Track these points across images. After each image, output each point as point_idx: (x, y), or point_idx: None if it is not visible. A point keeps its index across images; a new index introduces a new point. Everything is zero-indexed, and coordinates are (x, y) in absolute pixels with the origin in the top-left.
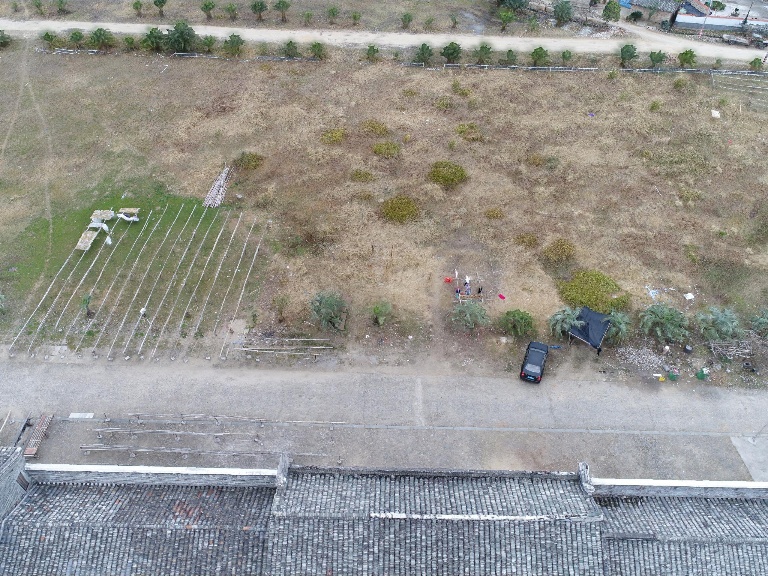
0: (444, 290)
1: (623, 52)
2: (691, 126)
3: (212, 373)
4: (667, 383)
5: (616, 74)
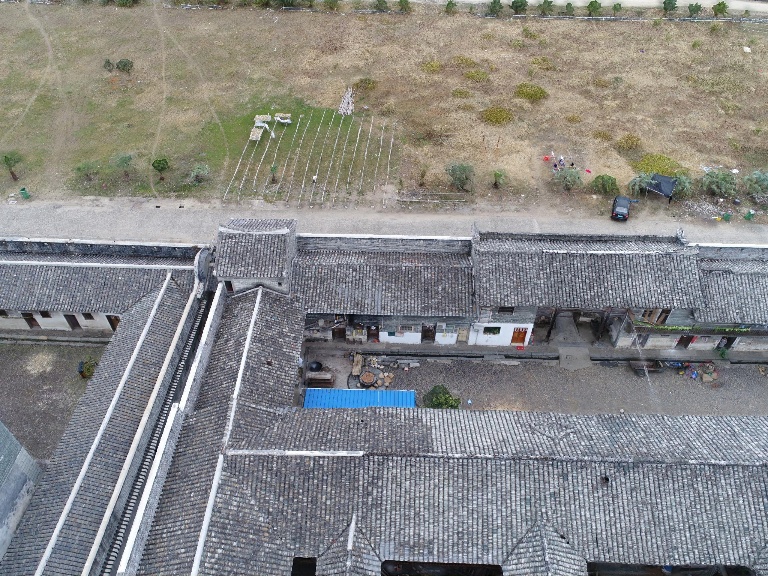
0: (543, 167)
1: (666, 4)
2: (727, 60)
3: (378, 216)
4: (723, 222)
5: (660, 21)
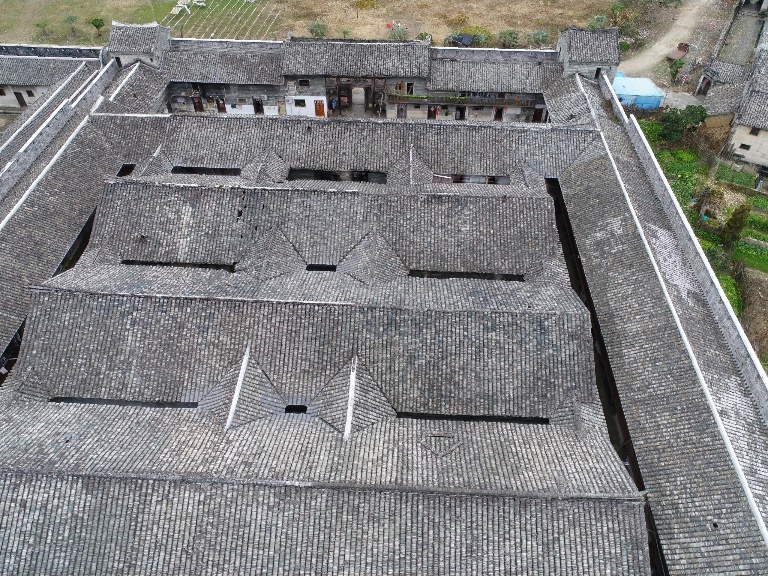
0: (386, 33)
1: None
2: None
3: None
4: None
5: None
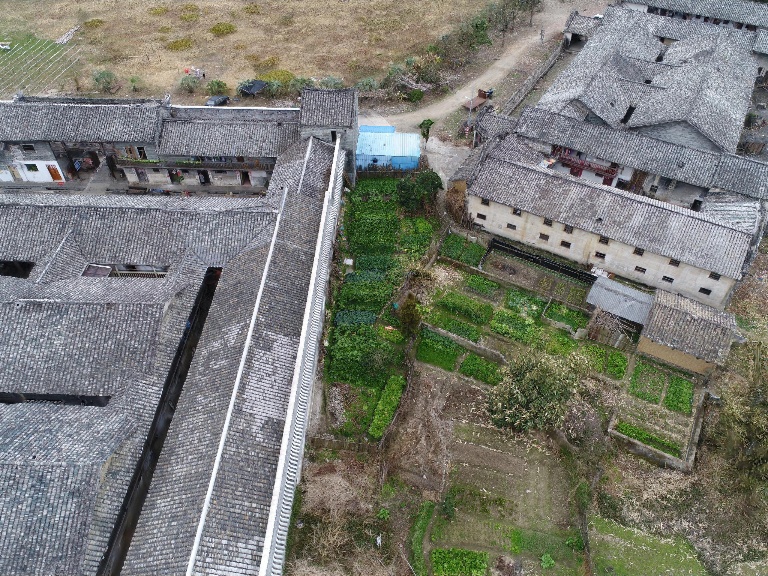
0: None
1: None
2: None
3: None
4: None
5: None
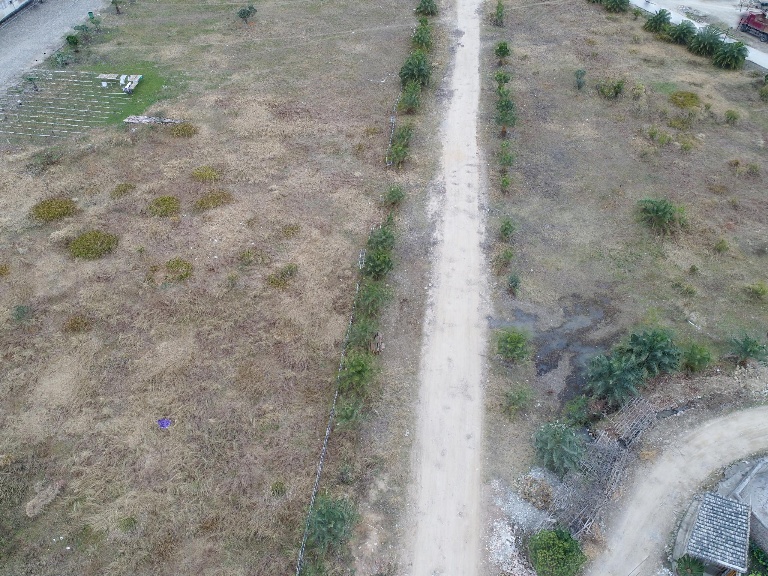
0: None
1: None
2: None
3: None
4: None
5: None
